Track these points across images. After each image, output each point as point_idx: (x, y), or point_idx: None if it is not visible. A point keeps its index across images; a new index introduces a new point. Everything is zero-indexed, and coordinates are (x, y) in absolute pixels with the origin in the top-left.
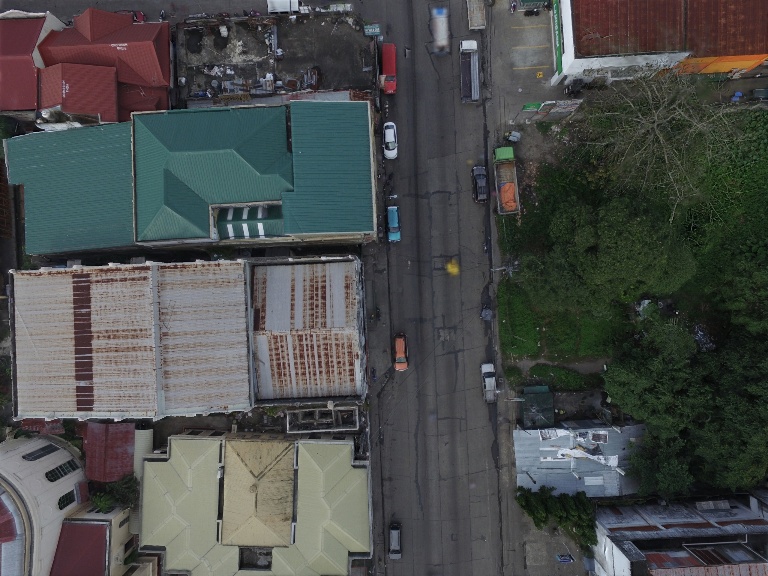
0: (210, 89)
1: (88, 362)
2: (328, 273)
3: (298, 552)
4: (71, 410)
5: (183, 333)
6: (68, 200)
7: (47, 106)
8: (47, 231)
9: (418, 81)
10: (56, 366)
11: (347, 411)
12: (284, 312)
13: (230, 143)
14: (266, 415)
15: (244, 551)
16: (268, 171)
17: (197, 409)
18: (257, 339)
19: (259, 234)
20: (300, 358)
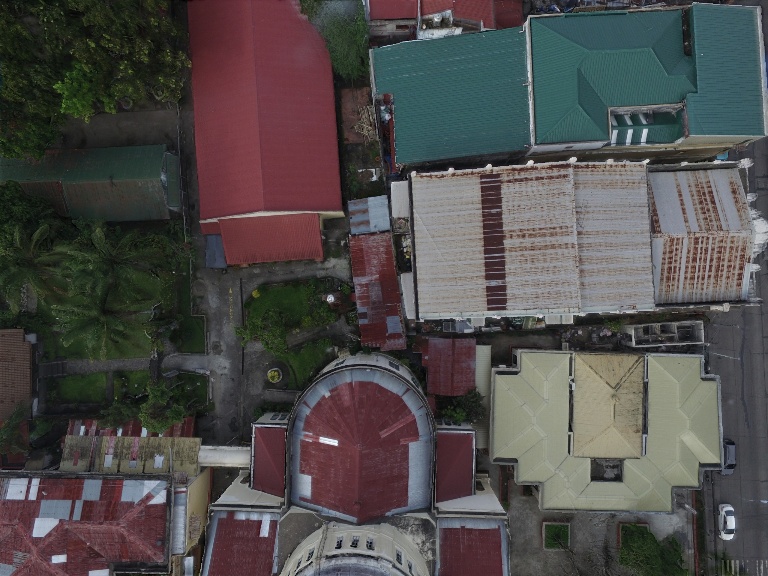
0: (556, 4)
1: (500, 261)
2: (712, 179)
3: (651, 463)
4: (480, 310)
5: (595, 232)
6: (446, 108)
7: (434, 11)
8: (421, 140)
9: (739, 2)
10: (463, 267)
11: (683, 327)
12: (676, 216)
13: (644, 42)
14: (595, 333)
15: (591, 464)
16: (674, 72)
17: (609, 308)
18: (653, 242)
19: (641, 141)
20: (692, 262)
